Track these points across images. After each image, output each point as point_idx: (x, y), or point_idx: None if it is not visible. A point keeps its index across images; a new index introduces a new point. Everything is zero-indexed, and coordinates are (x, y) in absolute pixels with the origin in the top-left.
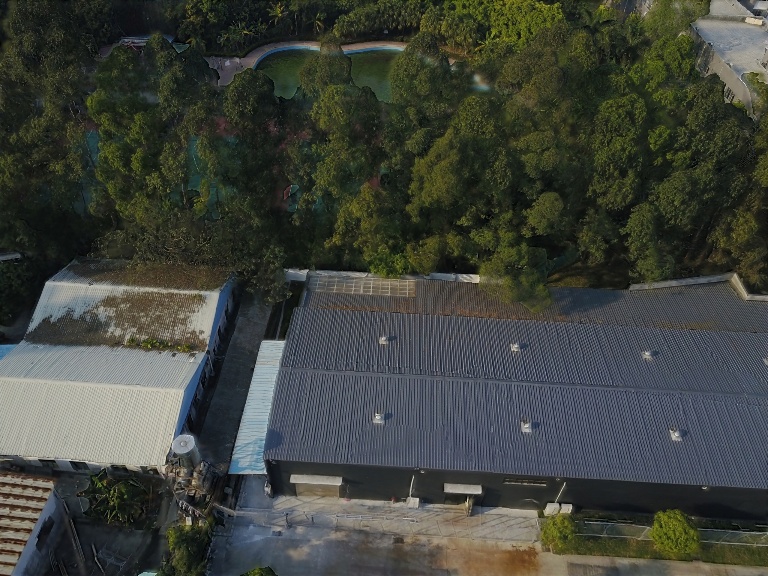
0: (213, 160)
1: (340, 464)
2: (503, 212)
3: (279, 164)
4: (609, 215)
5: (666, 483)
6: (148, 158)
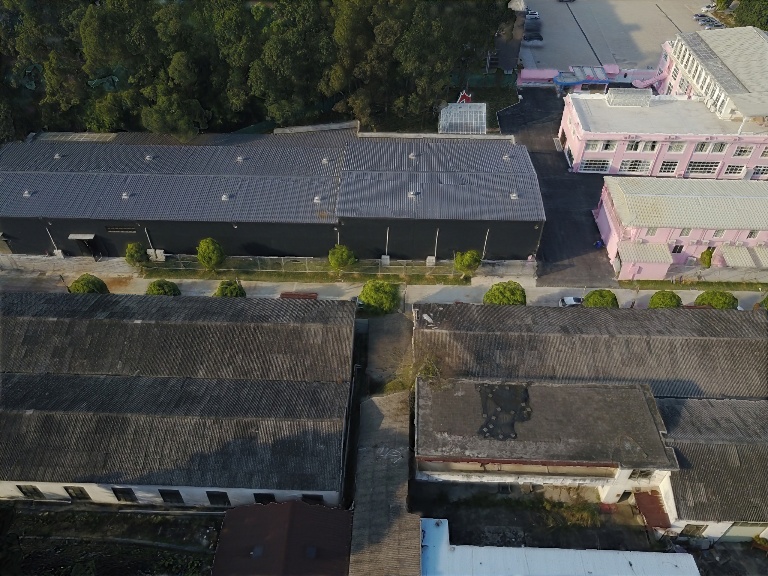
0: None
1: None
2: (158, 71)
3: None
4: (240, 72)
5: (203, 221)
6: None
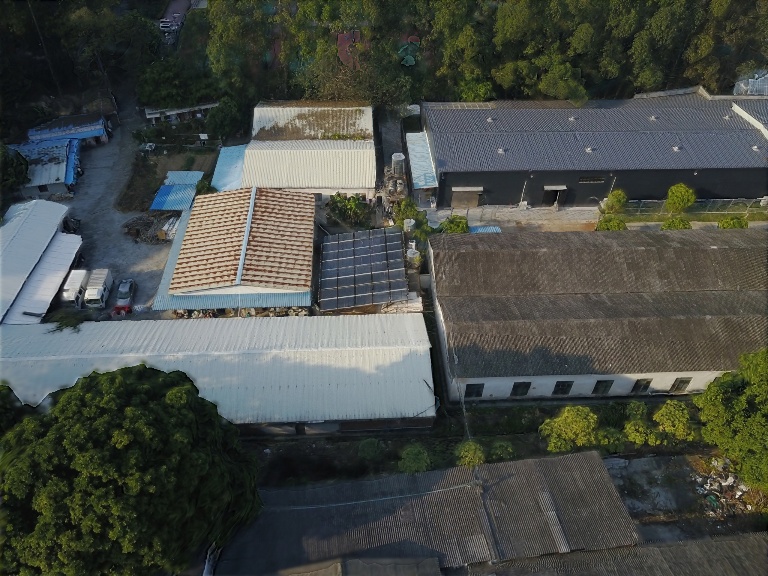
0: (374, 9)
1: (485, 171)
2: (553, 42)
3: (408, 17)
4: (620, 43)
5: (674, 169)
6: (331, 11)
